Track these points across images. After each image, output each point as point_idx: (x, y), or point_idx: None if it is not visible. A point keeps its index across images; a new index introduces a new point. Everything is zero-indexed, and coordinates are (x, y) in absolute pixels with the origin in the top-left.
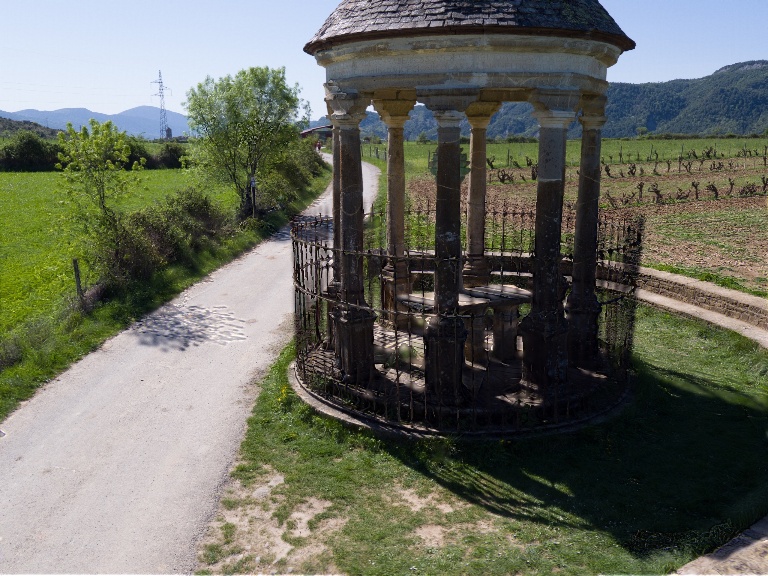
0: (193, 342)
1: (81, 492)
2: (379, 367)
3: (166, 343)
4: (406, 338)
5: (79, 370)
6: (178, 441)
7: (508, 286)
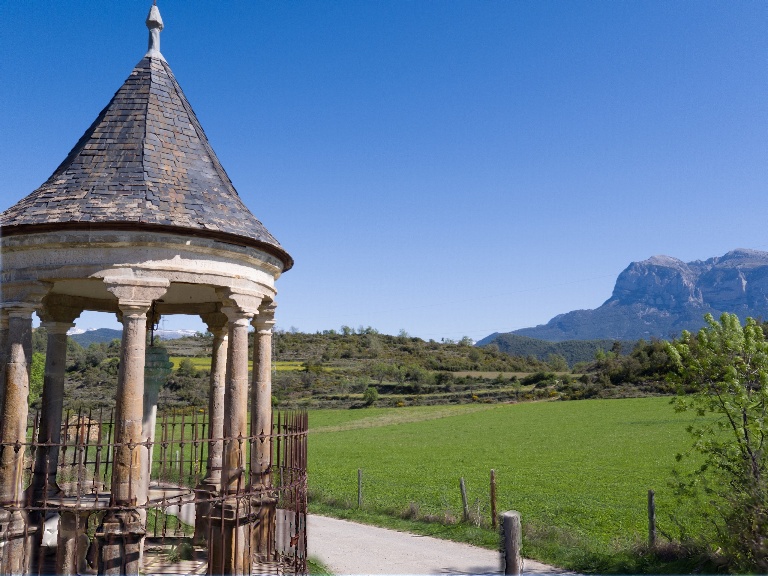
0: (456, 573)
1: (316, 537)
2: (197, 549)
3: (478, 568)
4: (198, 572)
5: (478, 550)
6: (308, 548)
7: (73, 503)
